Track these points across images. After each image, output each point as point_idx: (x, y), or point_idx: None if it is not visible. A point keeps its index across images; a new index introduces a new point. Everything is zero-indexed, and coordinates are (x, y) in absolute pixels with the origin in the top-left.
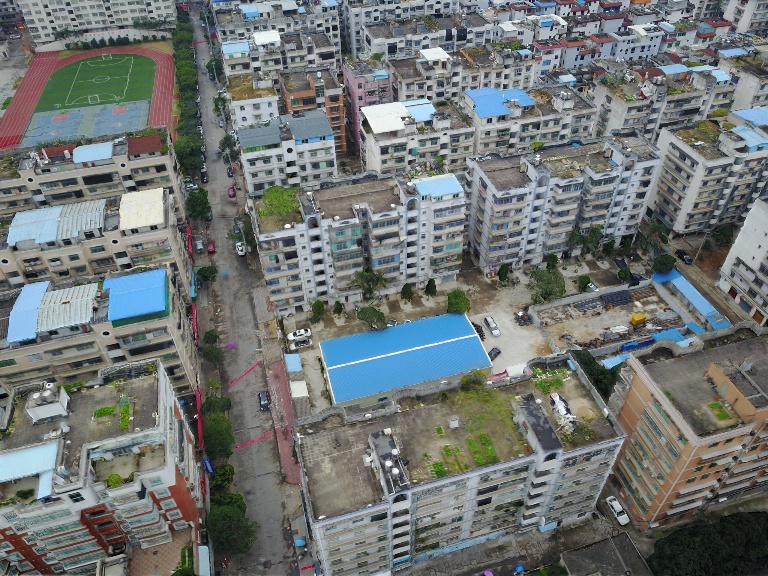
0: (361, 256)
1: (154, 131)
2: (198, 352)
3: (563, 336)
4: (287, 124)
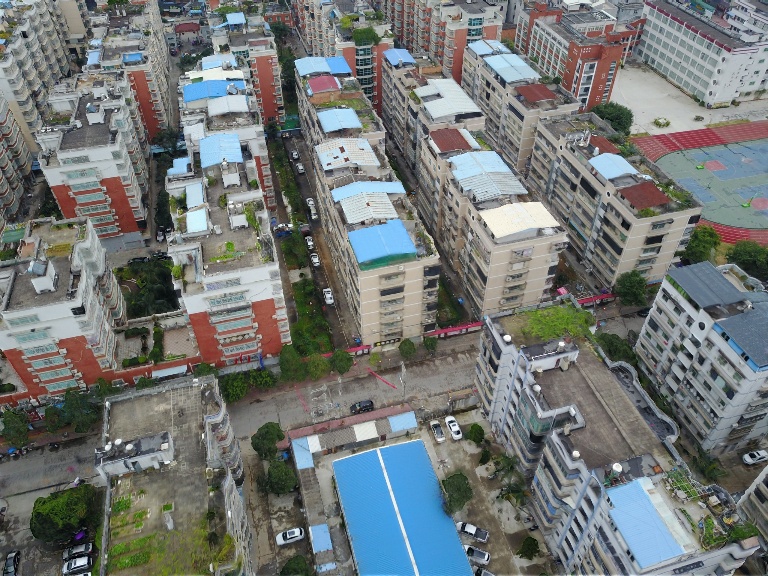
0: (529, 452)
1: (682, 197)
2: (423, 343)
3: None
4: (748, 306)
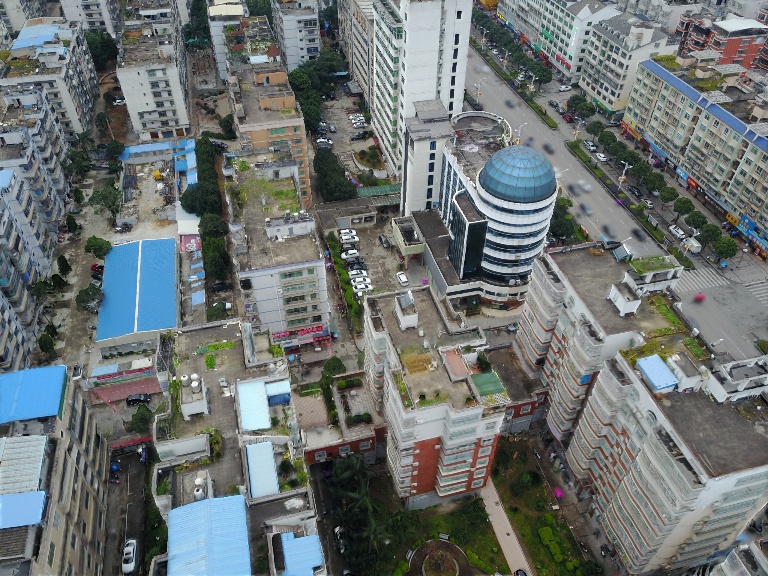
0: (19, 276)
1: None
2: None
3: (154, 211)
4: None
